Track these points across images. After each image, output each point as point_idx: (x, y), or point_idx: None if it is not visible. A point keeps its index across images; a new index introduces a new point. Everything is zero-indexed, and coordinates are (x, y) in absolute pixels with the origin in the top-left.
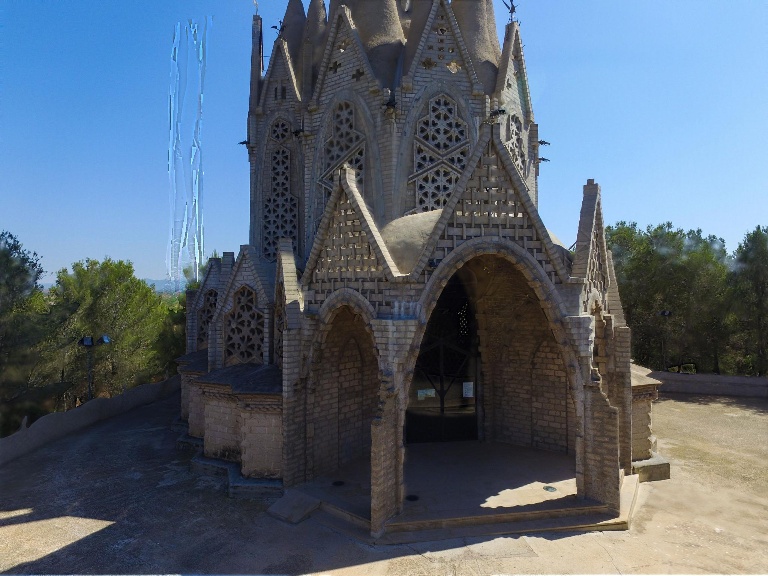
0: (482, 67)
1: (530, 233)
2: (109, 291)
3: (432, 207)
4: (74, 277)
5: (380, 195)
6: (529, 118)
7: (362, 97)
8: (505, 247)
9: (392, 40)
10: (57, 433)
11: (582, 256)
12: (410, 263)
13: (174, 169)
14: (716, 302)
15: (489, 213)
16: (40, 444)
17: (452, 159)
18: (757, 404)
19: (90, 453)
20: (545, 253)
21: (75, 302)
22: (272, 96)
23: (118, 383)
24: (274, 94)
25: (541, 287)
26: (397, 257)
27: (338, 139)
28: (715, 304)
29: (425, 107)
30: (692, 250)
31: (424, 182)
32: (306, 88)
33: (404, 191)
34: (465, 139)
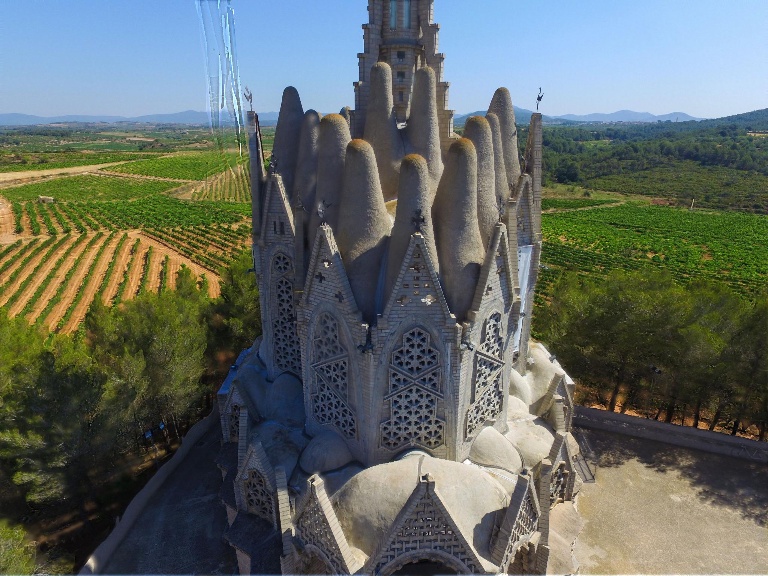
0: (463, 274)
1: (457, 543)
2: (157, 337)
3: (405, 416)
4: (127, 318)
5: (361, 405)
6: (511, 302)
7: (344, 319)
8: (435, 555)
9: (375, 242)
10: (140, 508)
11: (502, 545)
12: (367, 541)
13: (201, 14)
14: (705, 372)
15: (424, 534)
16: (131, 525)
17: (424, 379)
18: (710, 474)
19: (165, 542)
20: (468, 555)
21: (133, 388)
22: (272, 229)
23: (177, 408)
24: (273, 227)
25: (462, 575)
26: (359, 531)
27: (326, 341)
28: (704, 374)
29: (400, 339)
30: (699, 311)
31: (398, 398)
32: (298, 266)
33: (380, 406)
34: (436, 364)
